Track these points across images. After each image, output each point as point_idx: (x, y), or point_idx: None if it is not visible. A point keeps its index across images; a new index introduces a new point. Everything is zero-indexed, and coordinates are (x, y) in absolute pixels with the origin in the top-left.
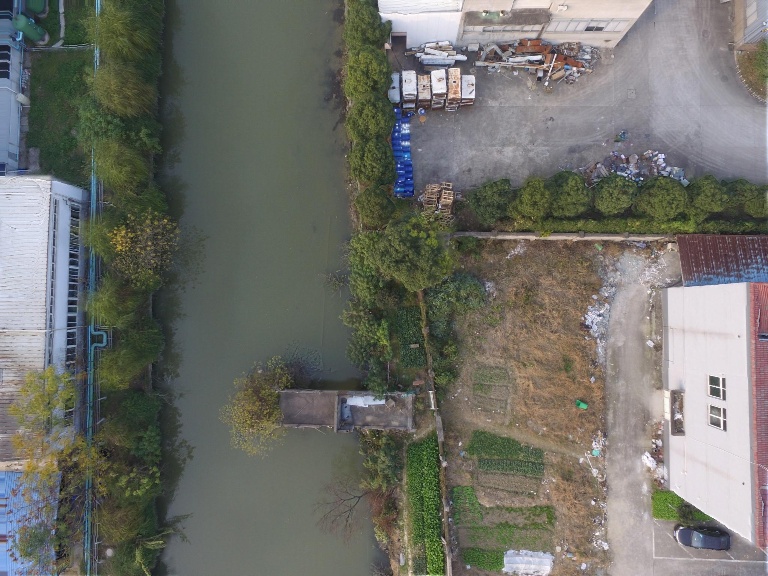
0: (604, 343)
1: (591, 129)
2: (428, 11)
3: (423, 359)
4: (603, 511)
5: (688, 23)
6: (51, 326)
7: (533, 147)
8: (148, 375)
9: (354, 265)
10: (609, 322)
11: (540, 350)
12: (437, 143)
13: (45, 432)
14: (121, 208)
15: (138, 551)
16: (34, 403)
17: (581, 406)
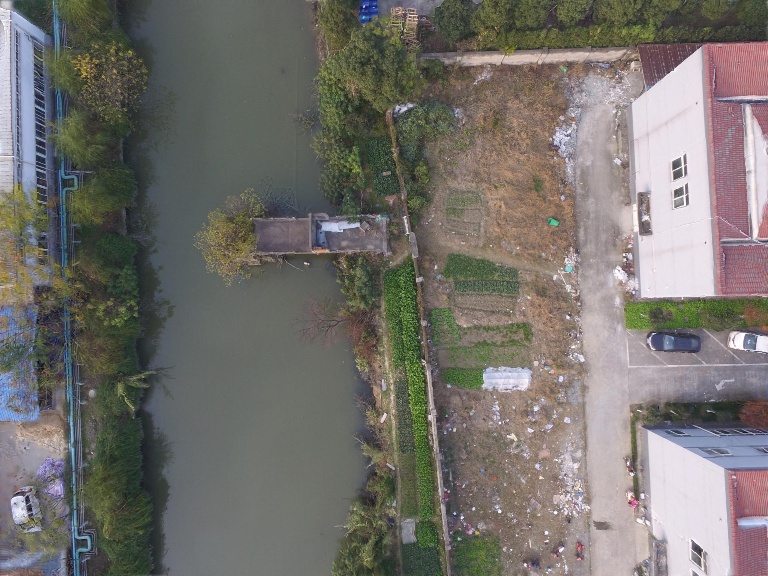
0: (573, 162)
1: None
2: None
3: (396, 186)
4: (578, 325)
5: None
6: (19, 156)
7: None
8: (122, 220)
9: (323, 95)
10: (577, 143)
11: (510, 171)
12: None
13: (19, 264)
14: (85, 43)
15: (120, 384)
16: (5, 230)
17: (552, 222)
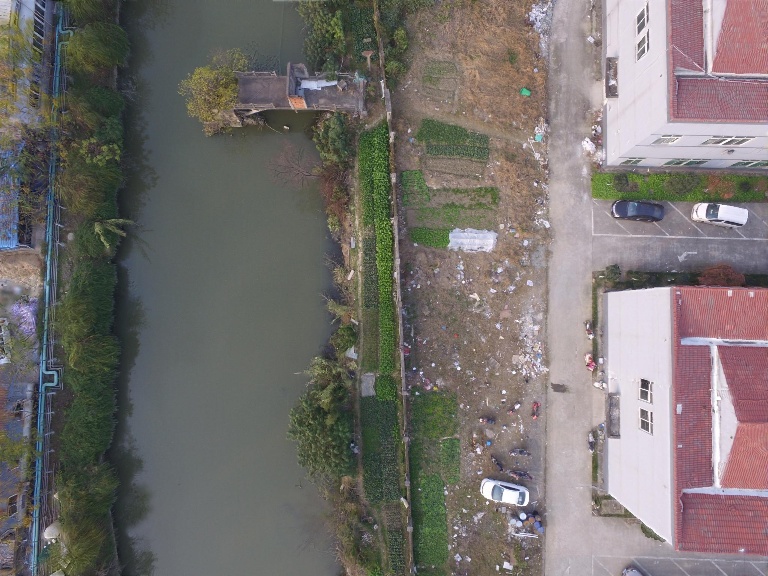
0: (547, 38)
1: None
2: None
3: (375, 52)
4: (545, 192)
5: None
6: None
7: None
8: (113, 77)
9: None
10: (552, 21)
11: (486, 42)
12: None
13: (9, 98)
14: None
15: (97, 223)
16: None
17: (524, 91)
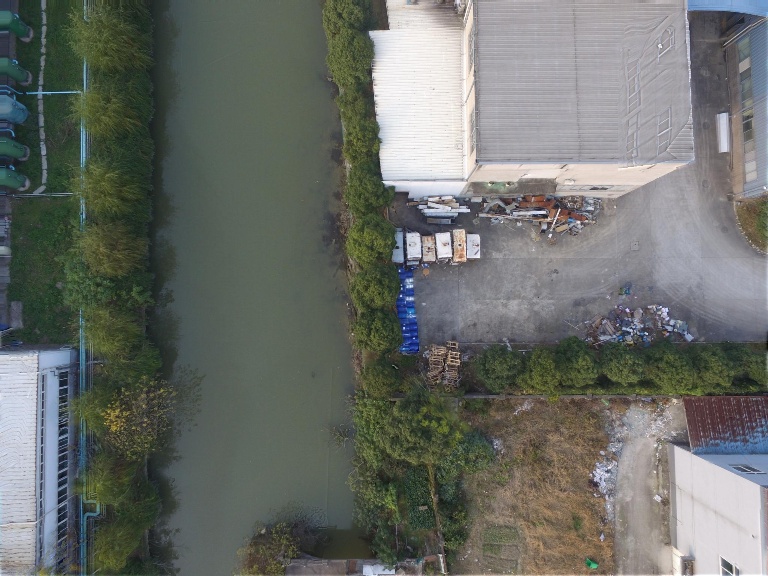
0: (612, 499)
1: (595, 282)
2: (433, 179)
3: (432, 522)
4: None
5: (688, 173)
6: (41, 512)
7: (538, 300)
8: (145, 541)
9: (360, 427)
10: (617, 477)
11: (550, 510)
12: (441, 297)
13: None
14: (113, 376)
15: None
16: None
17: (592, 566)
